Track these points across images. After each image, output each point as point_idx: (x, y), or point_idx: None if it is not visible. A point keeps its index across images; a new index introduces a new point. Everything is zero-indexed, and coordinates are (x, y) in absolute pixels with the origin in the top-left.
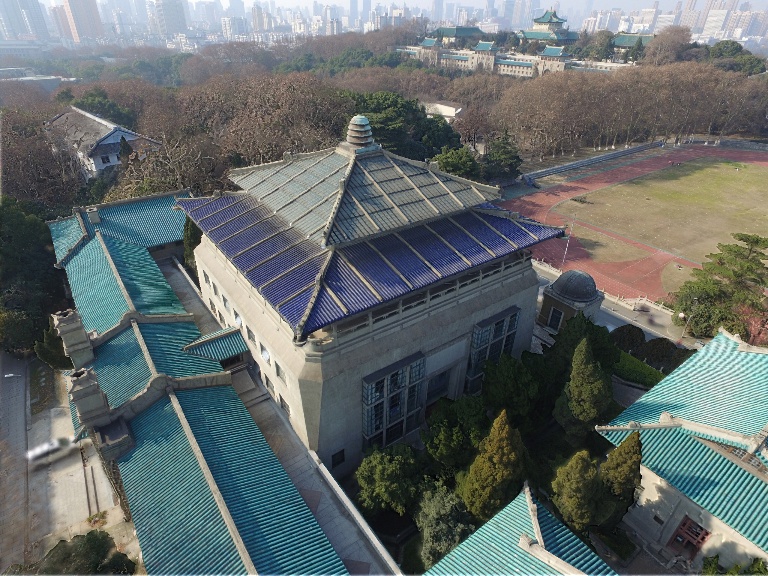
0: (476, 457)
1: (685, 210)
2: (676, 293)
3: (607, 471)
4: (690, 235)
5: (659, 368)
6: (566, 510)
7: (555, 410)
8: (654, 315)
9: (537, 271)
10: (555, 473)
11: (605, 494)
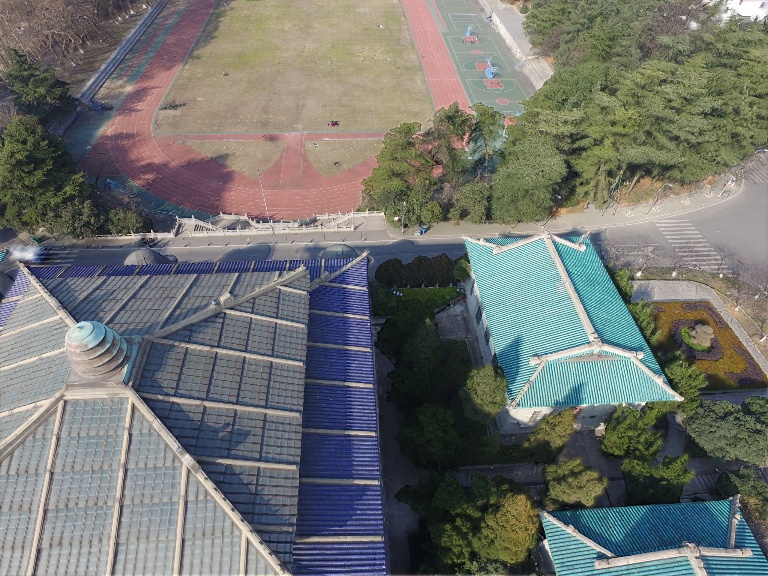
0: (505, 534)
1: (264, 74)
2: (365, 192)
3: (552, 439)
4: (291, 103)
5: (429, 282)
6: (571, 500)
7: (468, 414)
8: (369, 224)
9: (247, 240)
10: (478, 445)
11: (554, 451)
